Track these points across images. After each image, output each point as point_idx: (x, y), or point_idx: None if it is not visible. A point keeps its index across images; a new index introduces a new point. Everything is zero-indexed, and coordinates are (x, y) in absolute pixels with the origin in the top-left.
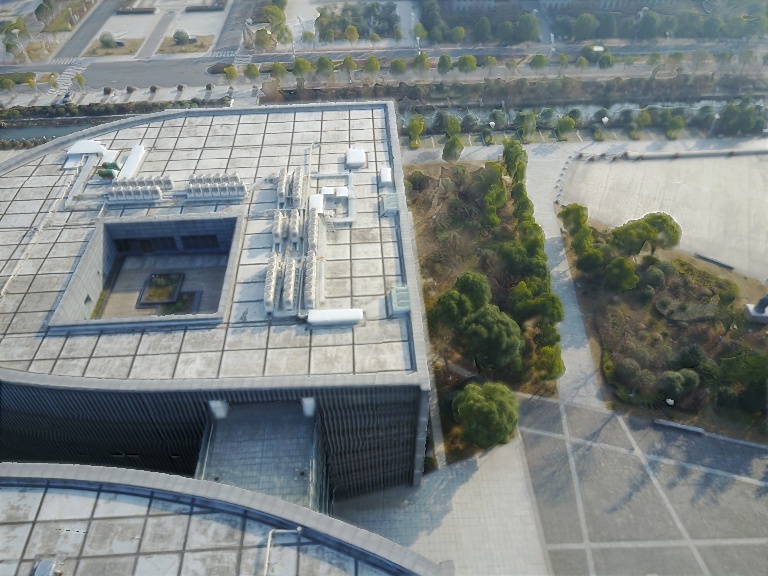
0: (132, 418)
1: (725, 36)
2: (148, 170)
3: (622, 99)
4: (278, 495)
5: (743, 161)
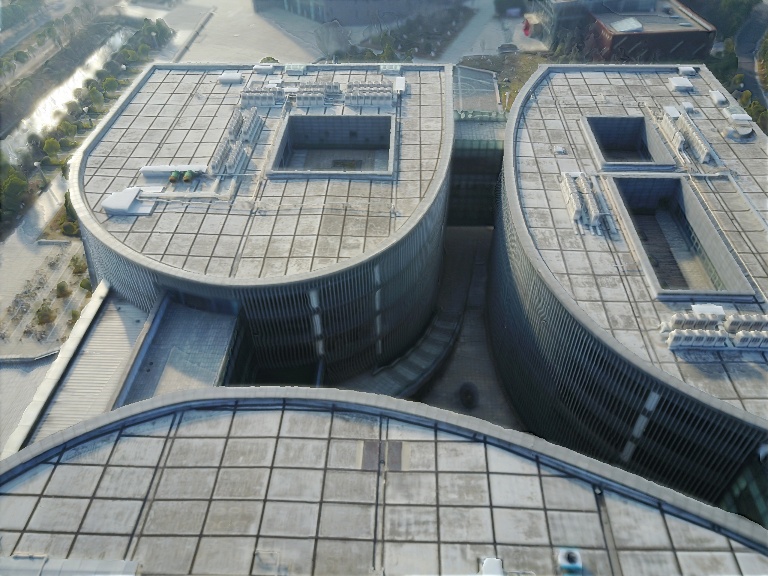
0: None
1: (28, 15)
2: None
3: (70, 71)
4: (494, 129)
5: (196, 47)
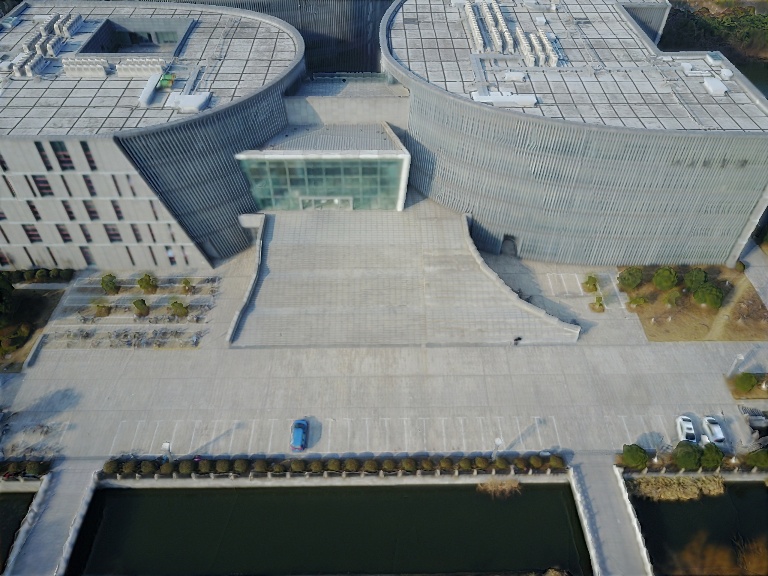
0: None
1: None
2: (139, 89)
3: None
4: None
5: None
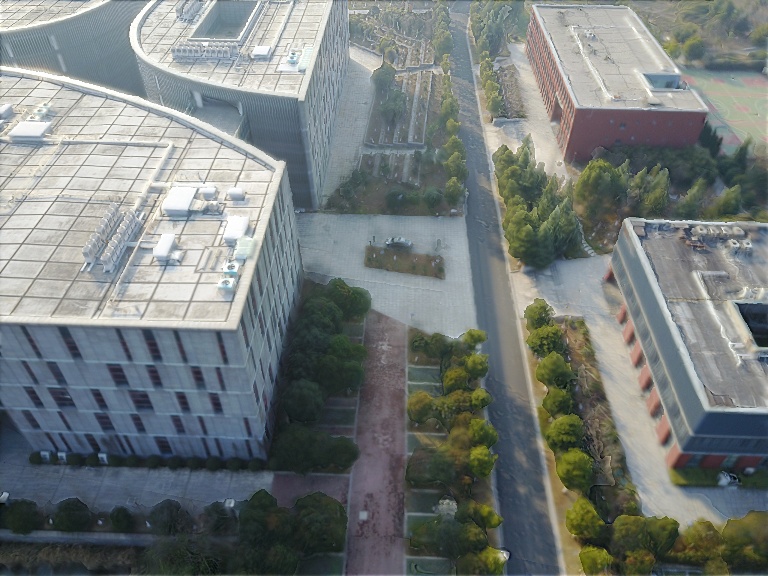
0: (142, 6)
1: None
2: None
3: None
4: None
5: None
